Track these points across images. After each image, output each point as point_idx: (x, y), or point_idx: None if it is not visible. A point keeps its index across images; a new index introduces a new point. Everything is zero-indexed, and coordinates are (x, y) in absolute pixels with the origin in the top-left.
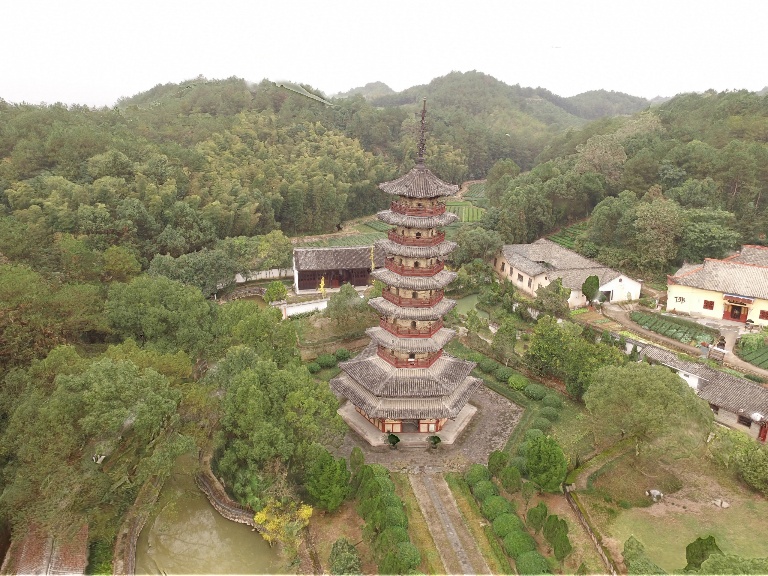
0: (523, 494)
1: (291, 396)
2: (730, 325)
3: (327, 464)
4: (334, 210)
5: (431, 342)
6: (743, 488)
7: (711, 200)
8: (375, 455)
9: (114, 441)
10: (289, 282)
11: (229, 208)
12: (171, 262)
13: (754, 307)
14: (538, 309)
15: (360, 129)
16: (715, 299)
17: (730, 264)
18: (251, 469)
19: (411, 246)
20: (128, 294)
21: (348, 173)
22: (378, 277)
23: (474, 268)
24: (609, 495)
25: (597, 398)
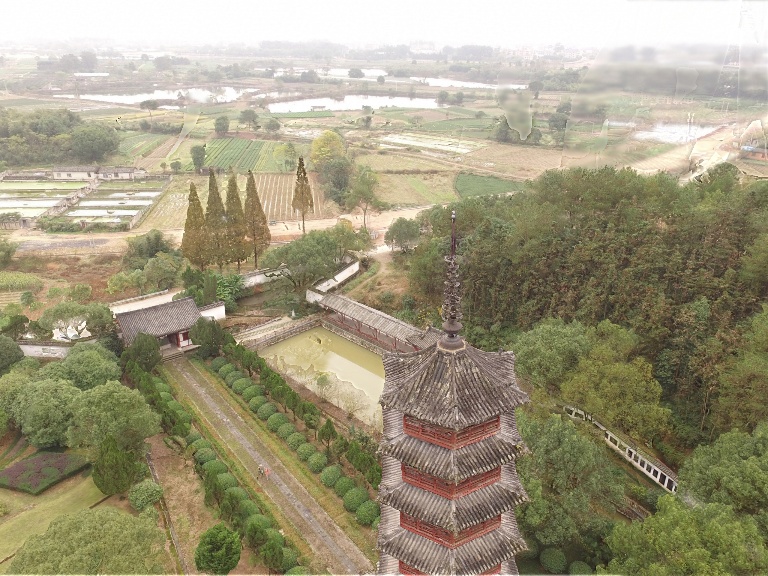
0: None
1: None
2: None
3: None
4: None
5: None
6: None
7: None
8: None
9: None
10: None
11: None
12: None
13: None
14: None
15: None
16: None
17: None
18: None
19: None
20: None
21: None
22: None
23: None
24: None
25: None
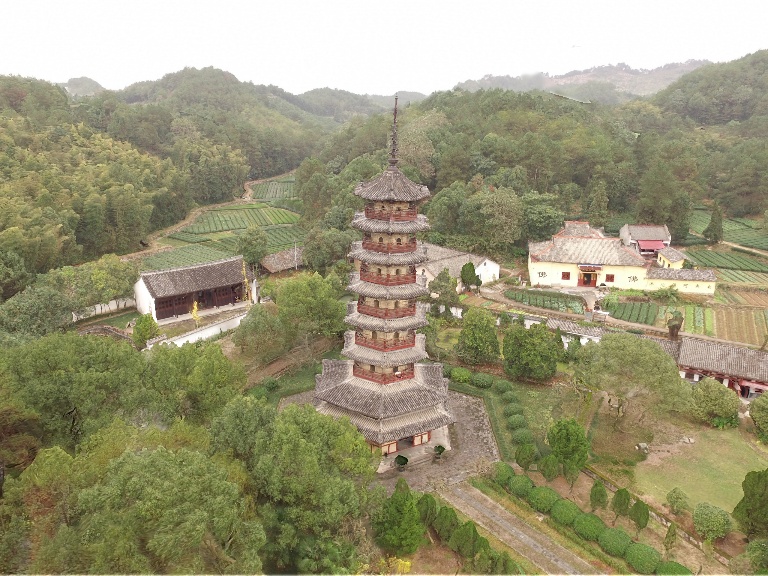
0: (570, 478)
1: (340, 441)
2: (586, 291)
3: (402, 505)
4: (139, 224)
5: (417, 351)
6: (691, 423)
7: (524, 185)
8: (389, 482)
9: (199, 557)
10: (133, 314)
11: (28, 234)
12: (0, 311)
13: (602, 273)
14: (429, 301)
15: (125, 131)
16: (571, 270)
17: (573, 239)
18: (324, 537)
19: (395, 253)
20: (37, 362)
21: (142, 181)
22: (357, 291)
23: (338, 270)
24: (613, 458)
25: (600, 373)
